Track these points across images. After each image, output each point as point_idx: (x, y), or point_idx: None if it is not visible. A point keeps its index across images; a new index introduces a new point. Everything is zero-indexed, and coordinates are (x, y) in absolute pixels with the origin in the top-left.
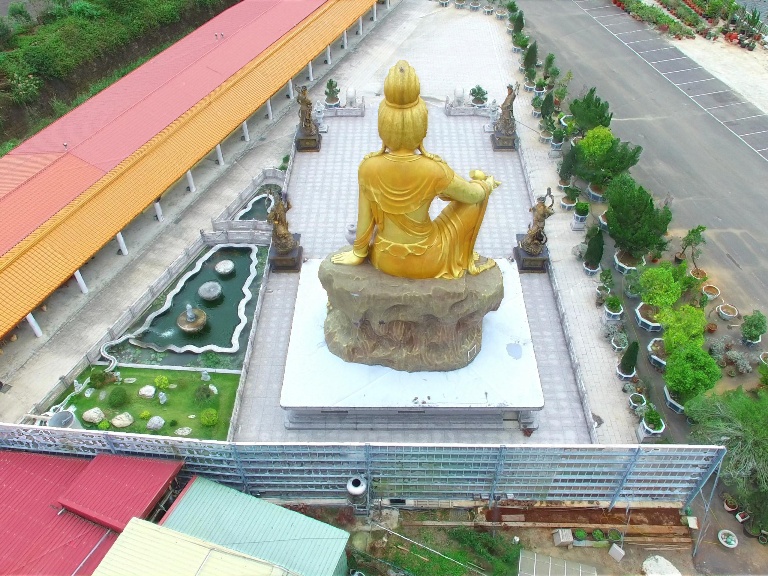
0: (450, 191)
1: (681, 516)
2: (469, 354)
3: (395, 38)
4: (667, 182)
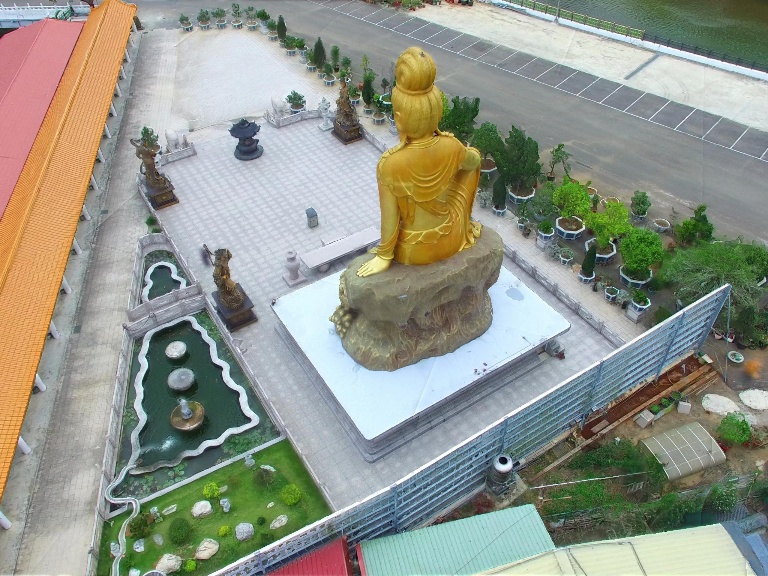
0: (465, 162)
1: (698, 359)
2: (491, 312)
3: (164, 73)
4: (495, 124)
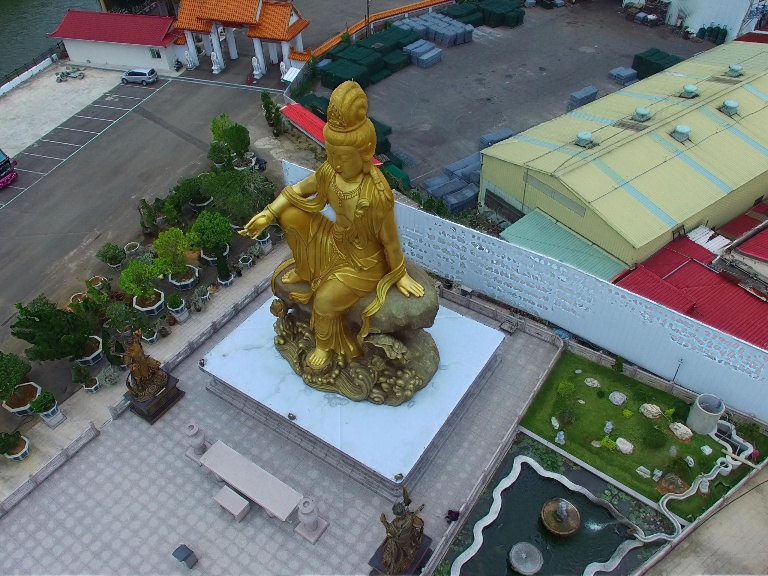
0: None
1: None
2: None
3: None
4: None
